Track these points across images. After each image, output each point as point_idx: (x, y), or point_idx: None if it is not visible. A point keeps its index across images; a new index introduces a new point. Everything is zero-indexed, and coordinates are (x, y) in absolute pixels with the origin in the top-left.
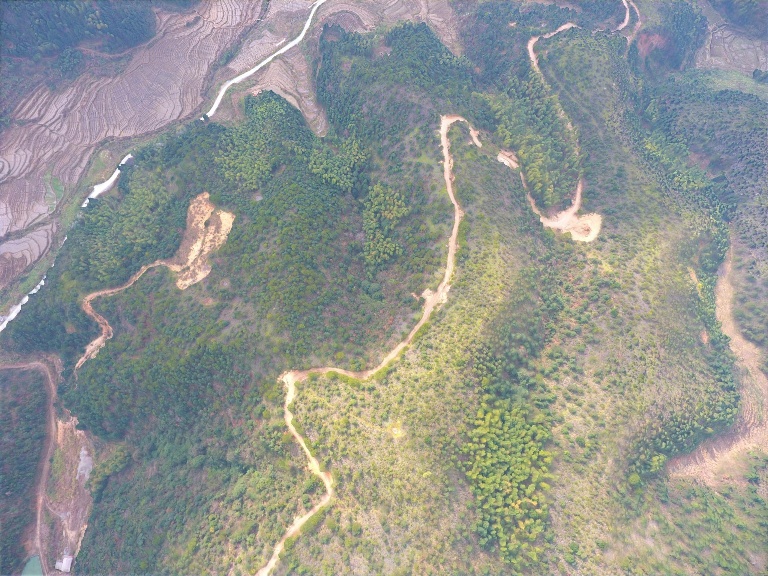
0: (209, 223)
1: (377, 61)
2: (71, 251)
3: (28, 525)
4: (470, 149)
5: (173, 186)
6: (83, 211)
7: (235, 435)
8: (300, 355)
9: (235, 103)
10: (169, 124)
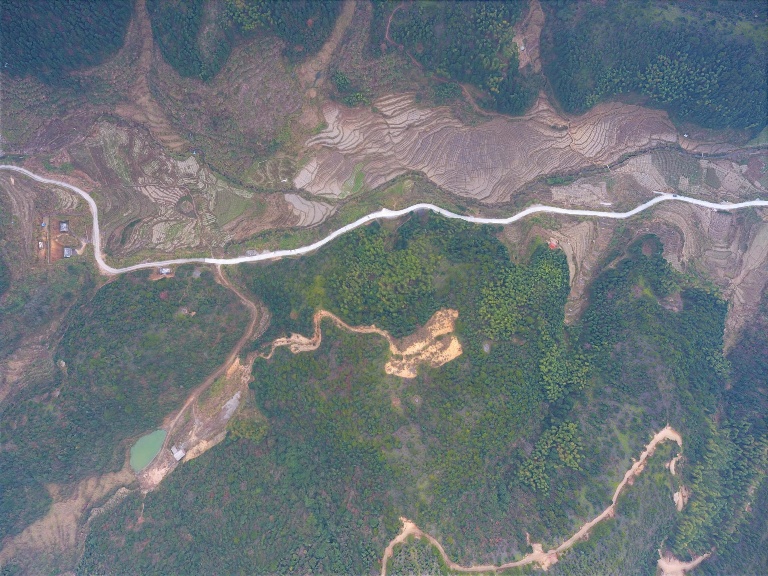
0: (441, 339)
1: (663, 314)
2: (336, 259)
3: (176, 409)
4: (663, 472)
5: (439, 280)
6: (365, 233)
7: (346, 519)
8: (428, 520)
9: (531, 235)
10: (471, 200)
